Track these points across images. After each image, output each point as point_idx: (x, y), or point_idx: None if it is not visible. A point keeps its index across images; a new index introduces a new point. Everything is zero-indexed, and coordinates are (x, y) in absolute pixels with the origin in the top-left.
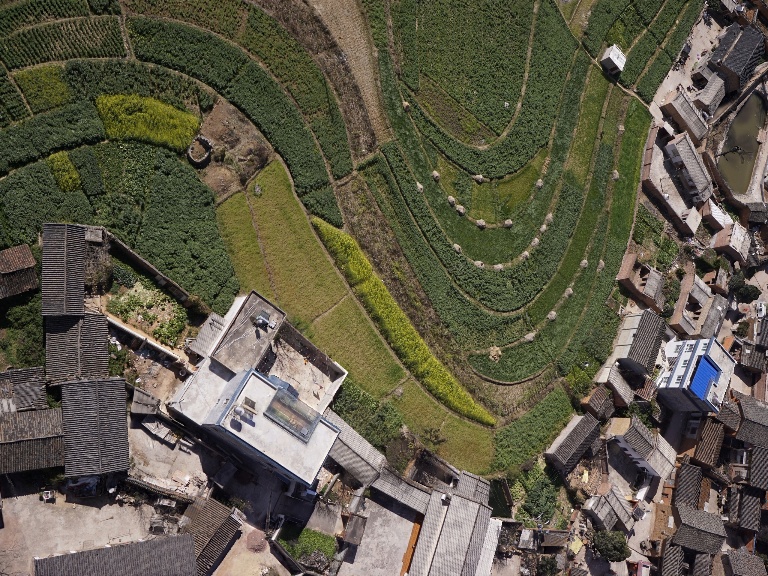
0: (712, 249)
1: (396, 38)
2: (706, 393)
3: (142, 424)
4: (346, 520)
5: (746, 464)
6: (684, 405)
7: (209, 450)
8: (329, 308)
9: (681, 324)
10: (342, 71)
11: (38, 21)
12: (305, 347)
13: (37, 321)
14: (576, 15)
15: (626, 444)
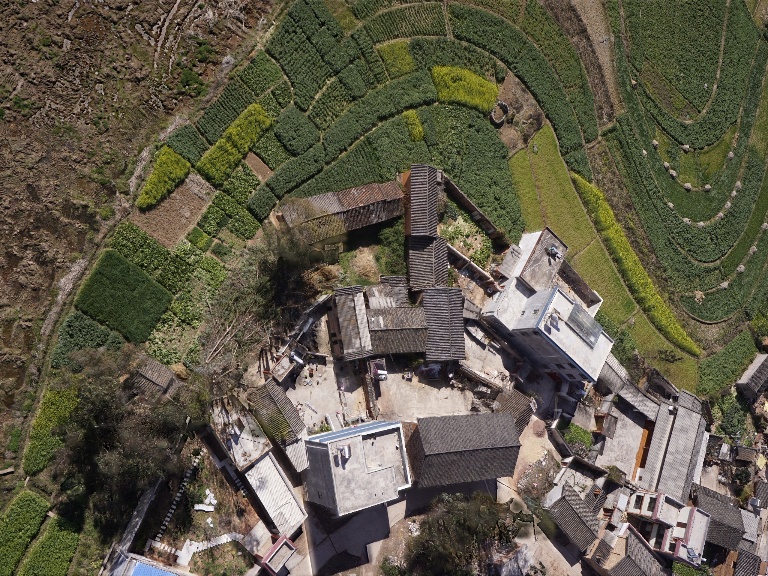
0: None
1: (626, 26)
2: None
3: (466, 327)
4: (598, 420)
5: None
6: None
7: (508, 353)
8: (583, 248)
9: None
10: (589, 53)
11: (390, 6)
12: (570, 278)
13: (400, 241)
14: (758, 9)
15: None
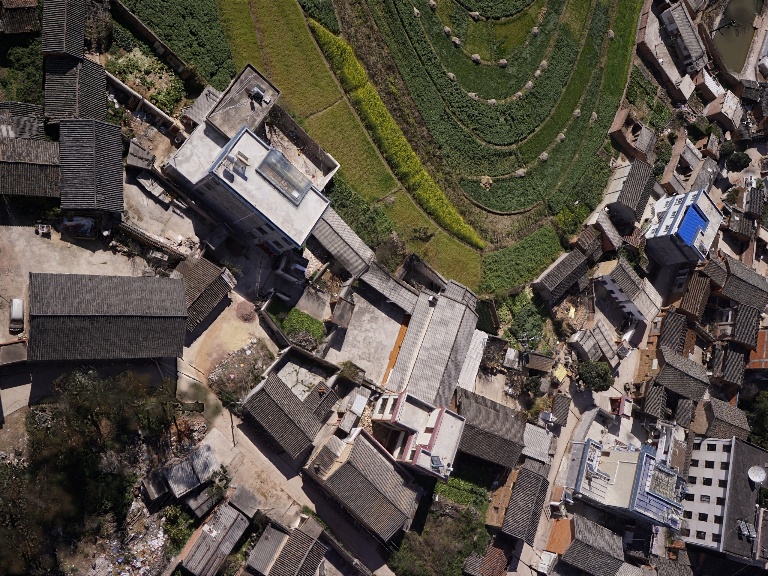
0: (704, 117)
1: None
2: (693, 239)
3: (137, 179)
4: None
5: (731, 321)
6: (671, 256)
7: (202, 217)
8: (323, 108)
9: (671, 182)
10: None
11: None
12: (299, 138)
13: (37, 64)
14: None
15: (613, 285)
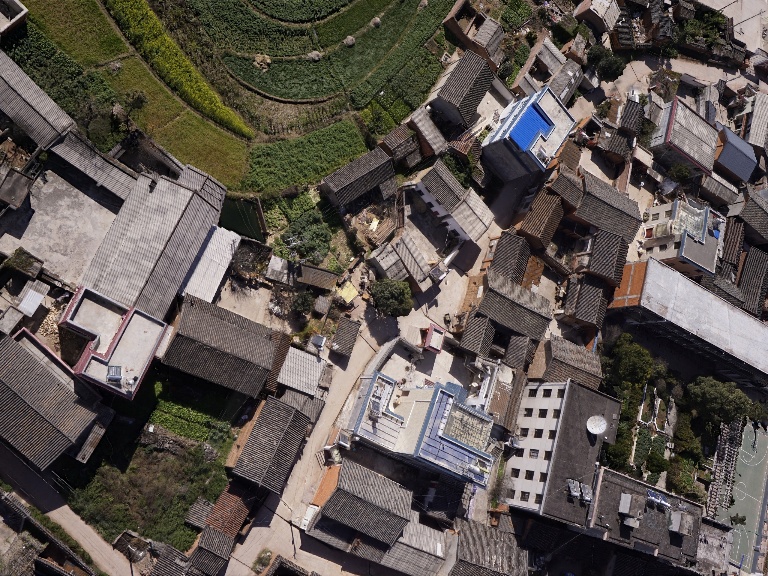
0: (572, 16)
1: None
2: (530, 144)
3: None
4: None
5: (589, 250)
6: (512, 168)
7: None
8: None
9: (521, 85)
10: None
11: None
12: None
13: None
14: None
15: (429, 195)
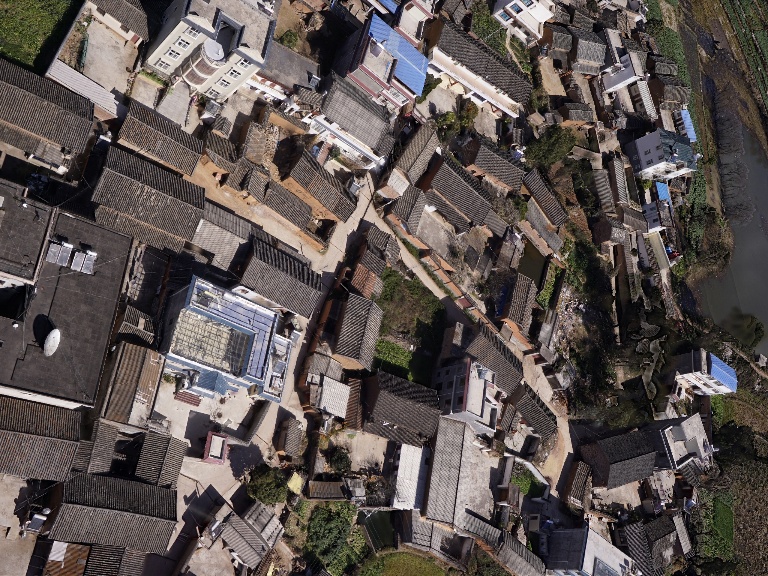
0: None
1: None
2: None
3: None
4: None
5: None
6: None
7: None
8: None
9: None
10: None
11: None
12: None
13: None
14: None
15: None
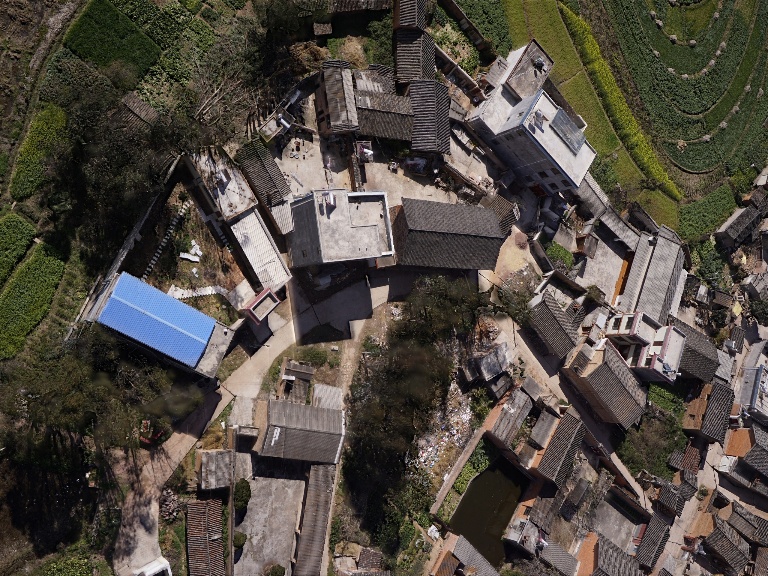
0: None
1: None
2: None
3: (452, 130)
4: (579, 243)
5: None
6: None
7: (492, 163)
8: (569, 78)
9: None
10: None
11: None
12: (555, 102)
13: (388, 35)
14: None
15: None
